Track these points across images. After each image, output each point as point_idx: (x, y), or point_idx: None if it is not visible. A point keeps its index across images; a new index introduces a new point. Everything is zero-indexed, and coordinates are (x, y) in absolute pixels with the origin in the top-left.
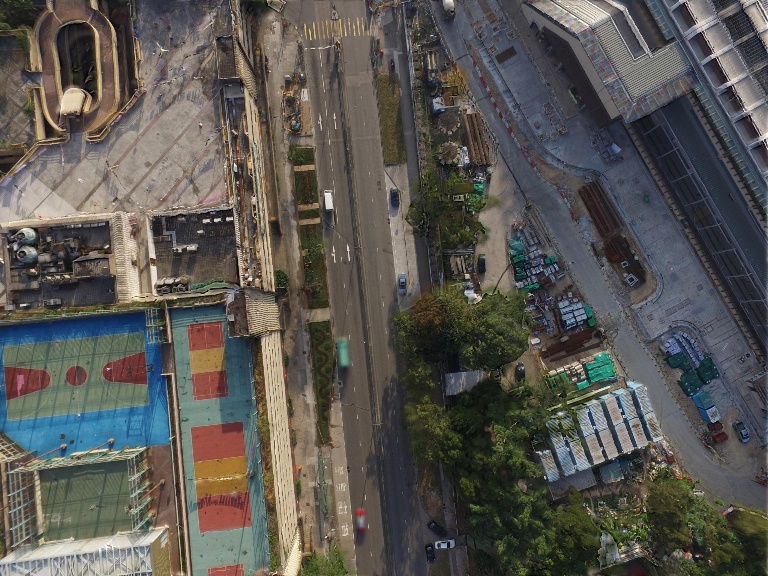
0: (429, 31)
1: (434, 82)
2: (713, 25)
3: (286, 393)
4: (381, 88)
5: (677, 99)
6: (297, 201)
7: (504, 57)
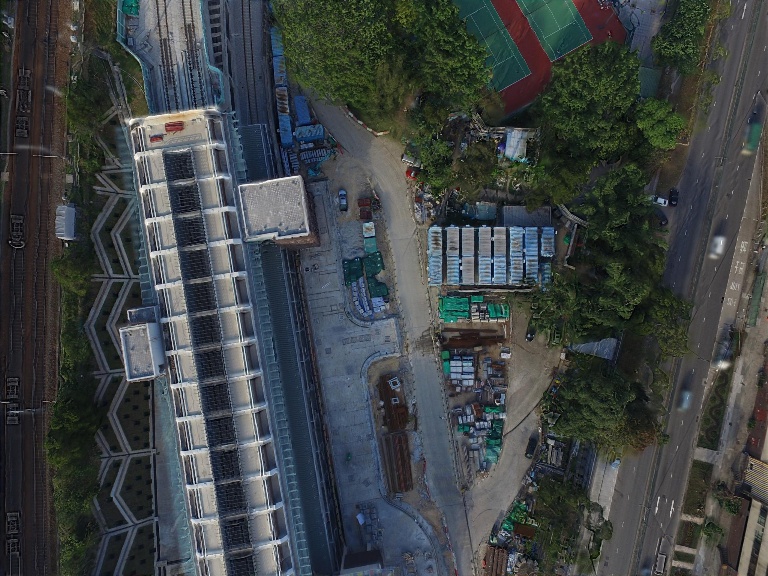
0: None
1: None
2: None
3: (765, 395)
4: None
5: None
6: (692, 574)
7: None
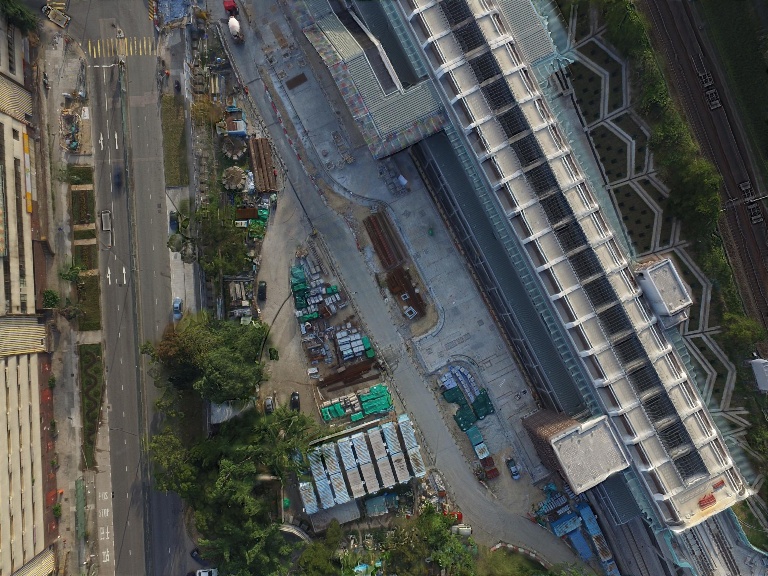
0: (218, 54)
1: (218, 106)
2: (461, 65)
3: (47, 416)
4: (165, 109)
5: (435, 136)
6: (73, 221)
7: (294, 83)
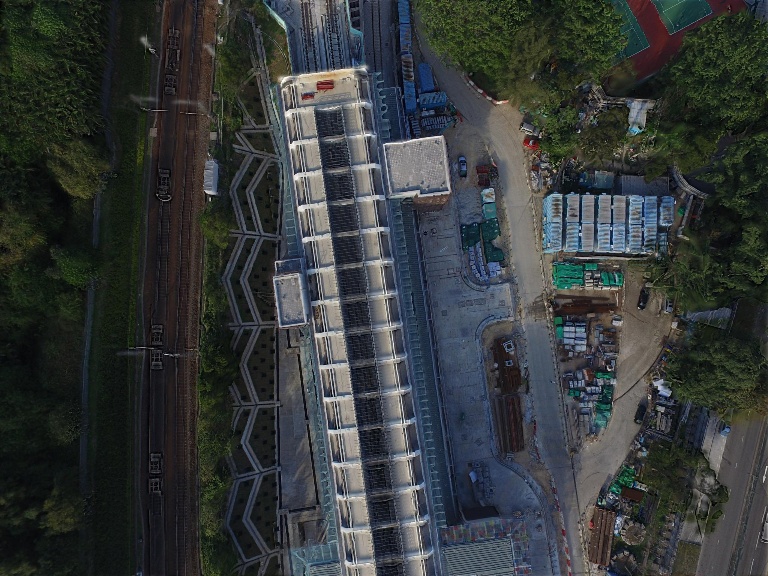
0: None
1: None
2: None
3: None
4: None
5: None
6: None
7: None
